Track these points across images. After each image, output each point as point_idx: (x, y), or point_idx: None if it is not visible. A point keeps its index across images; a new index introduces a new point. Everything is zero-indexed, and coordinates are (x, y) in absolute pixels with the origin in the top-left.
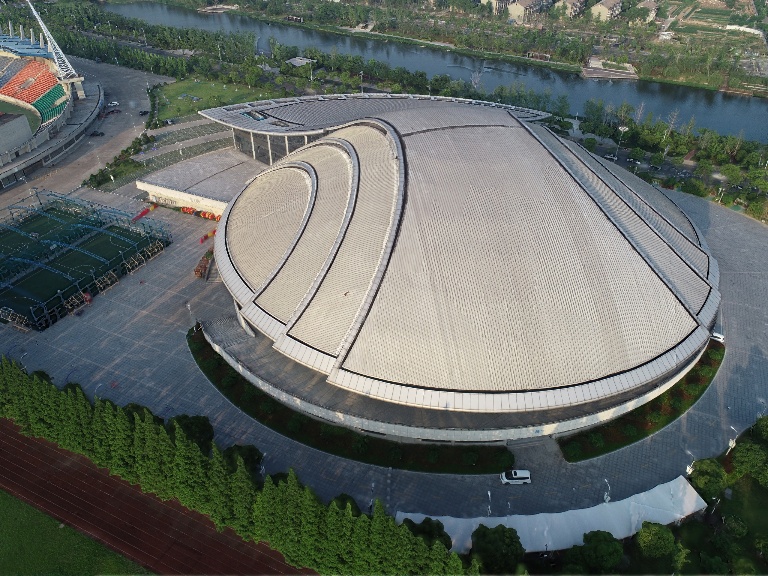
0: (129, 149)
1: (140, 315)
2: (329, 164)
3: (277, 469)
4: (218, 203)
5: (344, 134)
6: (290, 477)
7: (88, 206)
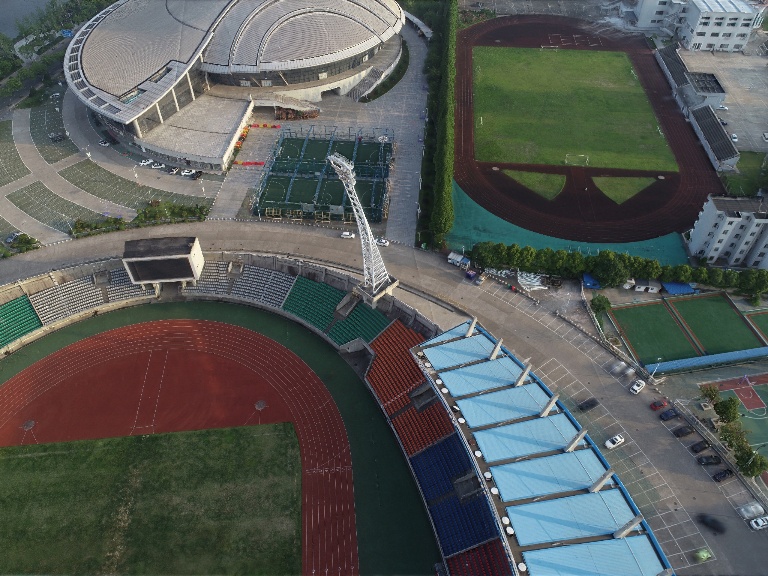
0: (121, 218)
1: (361, 121)
2: (291, 5)
3: (423, 64)
4: (246, 115)
5: (253, 4)
6: (451, 13)
7: (244, 197)
